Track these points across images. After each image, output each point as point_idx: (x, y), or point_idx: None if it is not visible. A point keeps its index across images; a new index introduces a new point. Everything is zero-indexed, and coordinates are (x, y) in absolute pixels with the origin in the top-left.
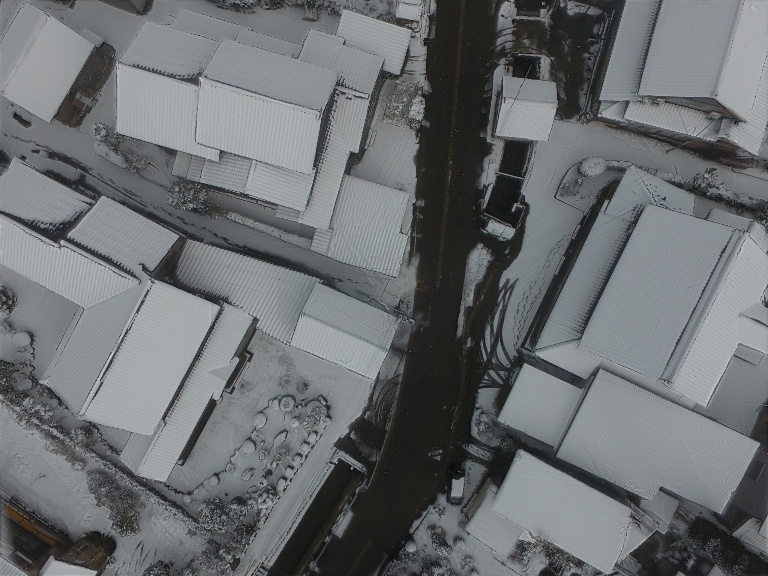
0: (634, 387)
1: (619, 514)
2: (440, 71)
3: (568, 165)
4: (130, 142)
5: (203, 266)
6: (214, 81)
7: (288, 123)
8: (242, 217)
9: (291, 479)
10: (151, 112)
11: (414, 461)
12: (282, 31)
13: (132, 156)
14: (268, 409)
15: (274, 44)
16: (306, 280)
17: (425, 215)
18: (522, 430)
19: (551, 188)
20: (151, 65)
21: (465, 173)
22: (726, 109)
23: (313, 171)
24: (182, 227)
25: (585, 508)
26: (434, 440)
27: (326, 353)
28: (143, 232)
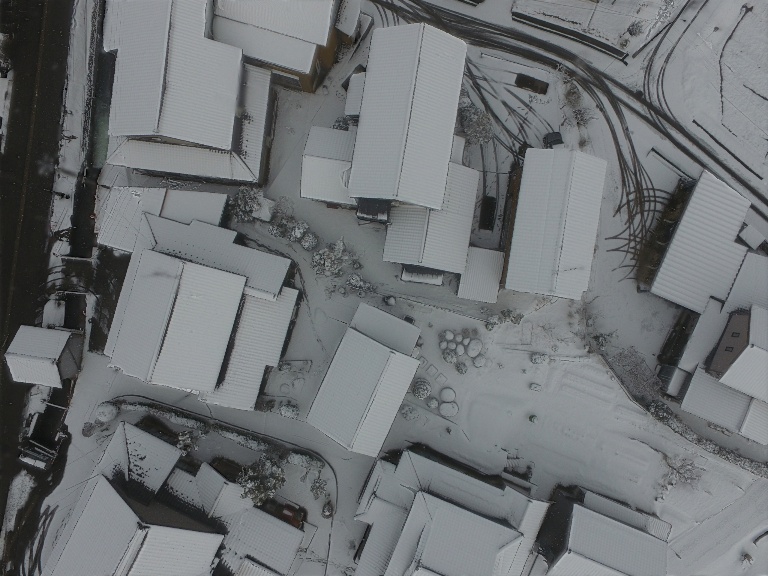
0: None
1: None
2: None
3: (108, 398)
4: None
5: None
6: None
7: None
8: None
9: None
10: None
11: None
12: None
13: None
14: None
15: None
16: None
17: None
18: None
19: (91, 420)
20: None
21: (12, 402)
22: None
23: None
24: None
25: None
26: None
27: None
28: None
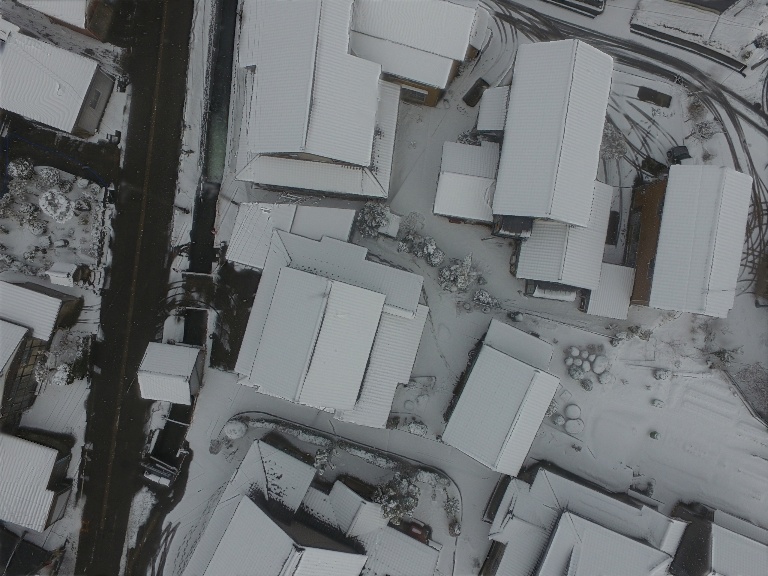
0: None
1: None
2: (113, 320)
3: (230, 415)
4: None
5: None
6: None
7: None
8: None
9: None
10: None
11: None
12: None
13: None
14: None
15: None
16: None
17: (93, 458)
18: None
19: (213, 436)
20: None
21: (133, 418)
22: (321, 406)
23: None
24: None
25: None
26: None
27: None
28: None
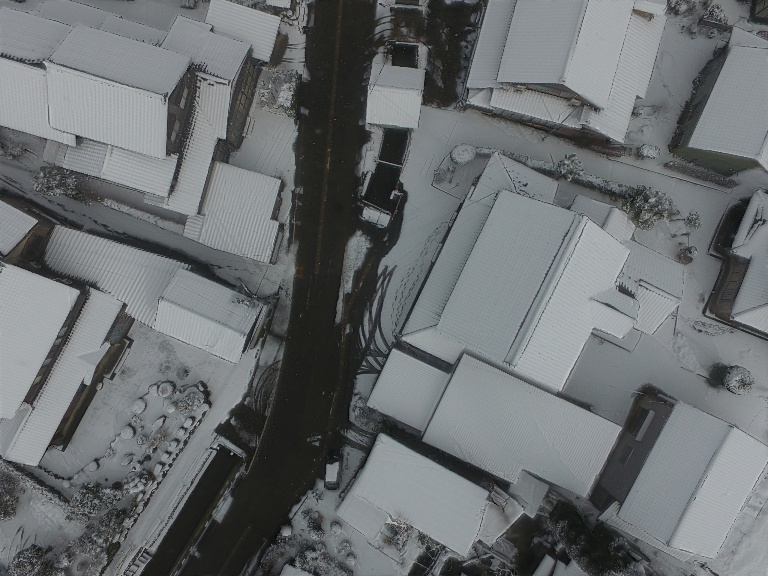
0: (498, 372)
1: (476, 497)
2: (319, 59)
3: (445, 153)
4: (4, 129)
5: (71, 252)
6: (59, 65)
7: (136, 108)
8: (118, 204)
9: (171, 464)
10: (4, 97)
11: (293, 447)
12: (160, 19)
13: (10, 143)
14: (148, 395)
15: (140, 30)
16: (174, 266)
17: (304, 202)
18: (390, 415)
19: (428, 176)
20: (1, 50)
21: (344, 161)
22: (579, 95)
23: (175, 157)
24: (62, 214)
25: (443, 491)
26: (313, 426)
27: (189, 338)
28: (0, 217)
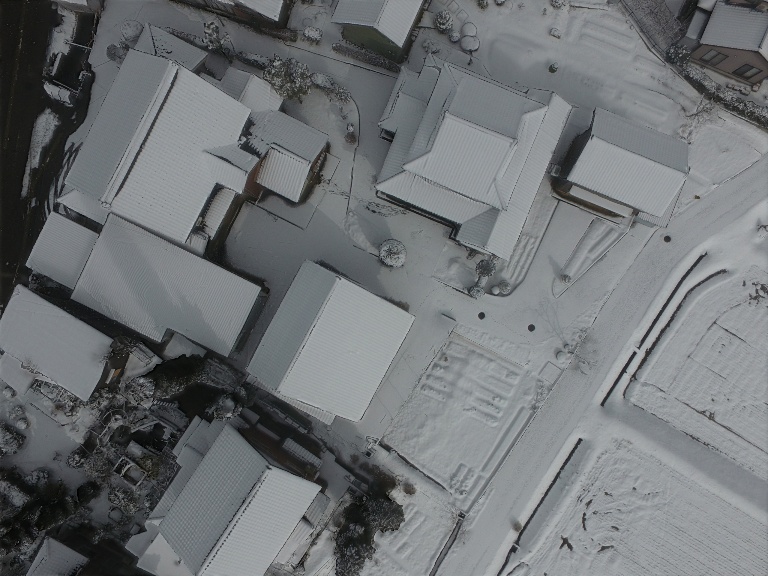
0: (144, 232)
1: (100, 344)
2: None
3: None
4: None
5: None
6: None
7: None
8: None
9: None
10: None
11: None
12: None
13: None
14: None
15: None
16: None
17: None
18: (47, 275)
19: None
20: None
21: (35, 42)
22: None
23: None
24: None
25: (71, 339)
26: None
27: None
28: None
